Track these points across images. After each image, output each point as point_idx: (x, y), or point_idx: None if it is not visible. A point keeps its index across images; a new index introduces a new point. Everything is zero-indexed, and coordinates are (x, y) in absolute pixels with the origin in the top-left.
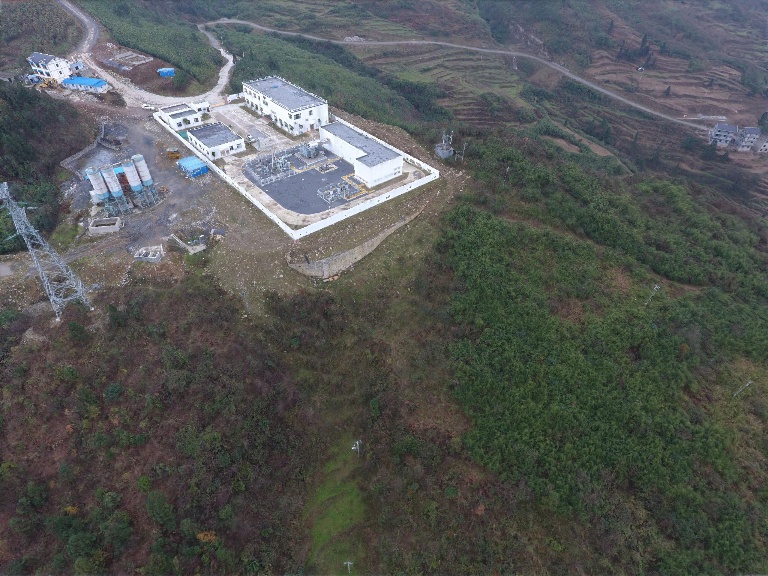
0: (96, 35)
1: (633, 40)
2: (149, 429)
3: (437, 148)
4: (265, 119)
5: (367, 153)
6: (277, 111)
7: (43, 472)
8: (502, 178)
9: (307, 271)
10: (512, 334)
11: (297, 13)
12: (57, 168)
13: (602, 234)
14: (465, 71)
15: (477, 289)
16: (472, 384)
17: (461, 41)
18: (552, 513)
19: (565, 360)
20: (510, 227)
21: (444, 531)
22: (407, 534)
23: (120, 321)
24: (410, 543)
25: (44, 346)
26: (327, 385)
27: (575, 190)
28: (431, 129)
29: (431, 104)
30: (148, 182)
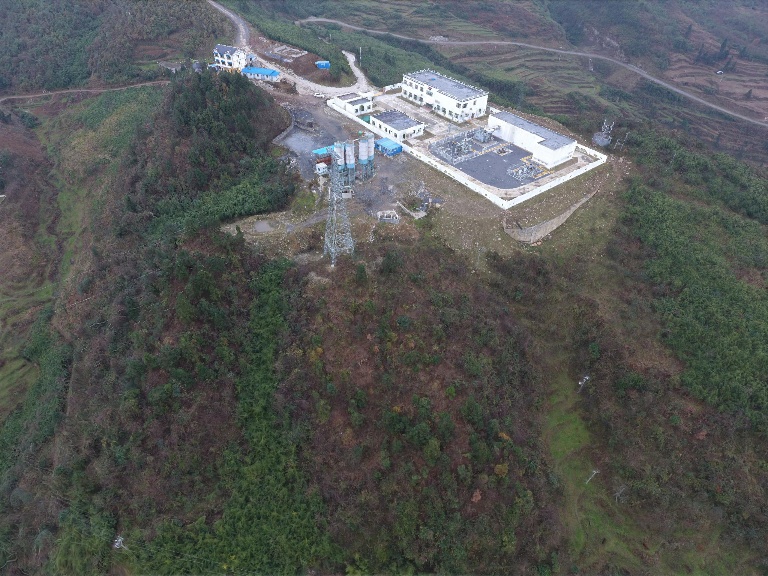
0: (247, 30)
1: (711, 44)
2: (440, 352)
3: (595, 136)
4: (426, 108)
5: (544, 138)
6: (442, 101)
7: (357, 383)
8: (663, 164)
9: (518, 236)
10: (709, 294)
11: (383, 13)
12: (271, 145)
13: (764, 215)
14: (545, 71)
15: (669, 256)
16: (684, 333)
17: (539, 42)
18: (767, 439)
19: (760, 317)
20: (684, 205)
21: (672, 451)
22: (636, 453)
23: (392, 268)
24: (640, 461)
25: (333, 286)
26: (544, 333)
27: (733, 176)
28: (583, 120)
29: (521, 101)
30: (372, 157)
